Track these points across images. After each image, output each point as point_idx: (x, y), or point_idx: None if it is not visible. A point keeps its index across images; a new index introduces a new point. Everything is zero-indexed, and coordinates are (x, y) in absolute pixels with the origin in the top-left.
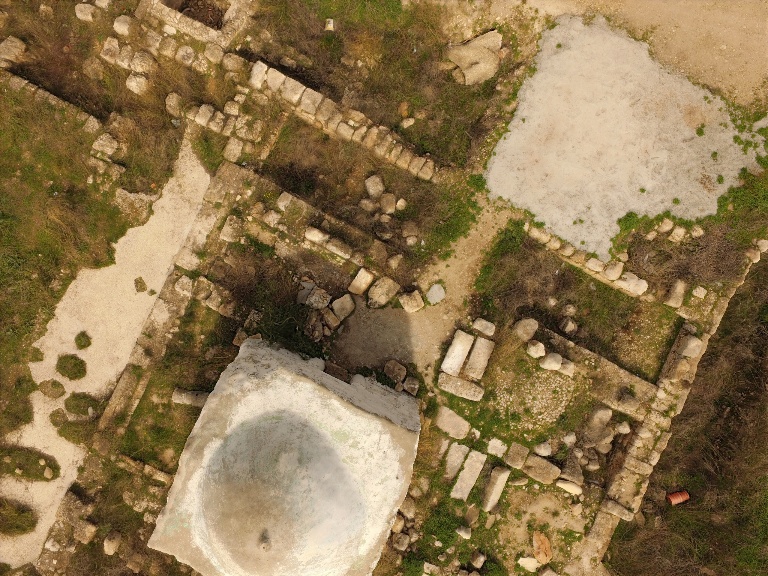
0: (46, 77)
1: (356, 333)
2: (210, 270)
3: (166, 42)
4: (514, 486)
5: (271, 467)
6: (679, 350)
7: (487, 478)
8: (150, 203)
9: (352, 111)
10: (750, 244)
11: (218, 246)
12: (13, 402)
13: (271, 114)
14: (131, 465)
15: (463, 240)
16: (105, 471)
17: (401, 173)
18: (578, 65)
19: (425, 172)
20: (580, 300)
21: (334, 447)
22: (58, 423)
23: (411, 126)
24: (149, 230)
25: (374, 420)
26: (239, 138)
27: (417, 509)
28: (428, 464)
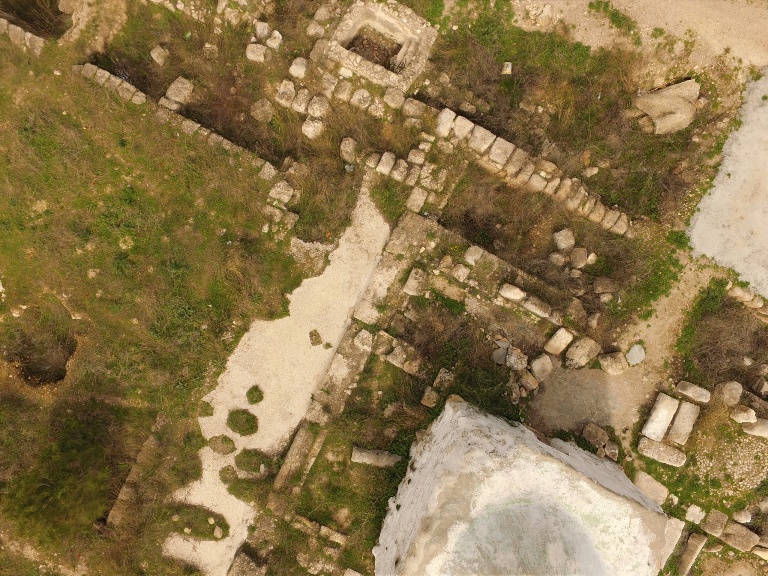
0: (215, 120)
1: (551, 394)
2: (390, 324)
3: (342, 85)
4: (707, 552)
5: (542, 560)
6: None
7: (683, 545)
8: (326, 253)
9: (545, 162)
10: None
11: (399, 299)
12: (181, 458)
13: (454, 162)
14: (307, 526)
15: (664, 299)
16: (277, 531)
17: (593, 226)
18: None
19: (620, 226)
20: None
21: (586, 532)
22: (228, 480)
23: (594, 175)
24: (325, 281)
25: (625, 503)
26: (424, 188)
27: None
28: None
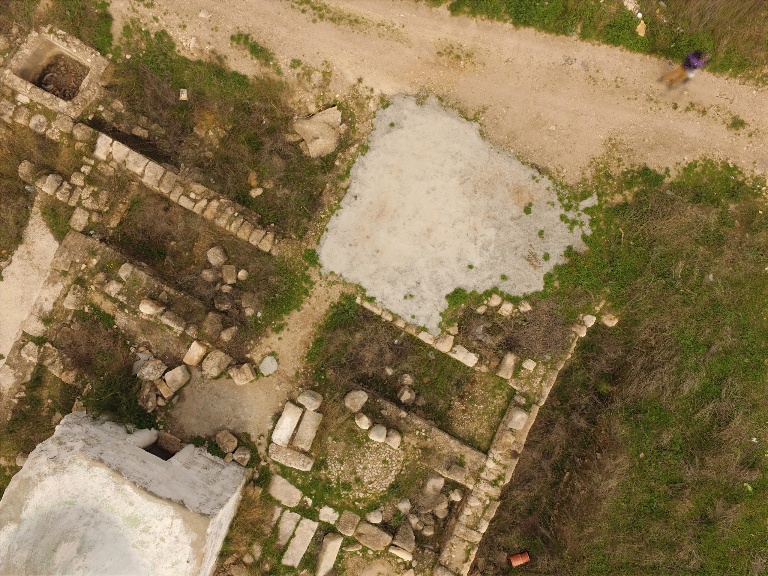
0: None
1: (191, 403)
2: (56, 336)
3: (19, 111)
4: (349, 551)
5: (46, 558)
6: (507, 421)
7: (319, 544)
8: None
9: (193, 184)
10: (576, 319)
11: (64, 313)
12: None
13: (119, 184)
14: None
15: (296, 313)
16: None
17: (242, 245)
18: (410, 144)
19: (264, 245)
20: (416, 370)
21: (124, 532)
22: None
23: (260, 196)
24: None
25: (166, 505)
26: (85, 208)
27: (250, 575)
28: (258, 532)
